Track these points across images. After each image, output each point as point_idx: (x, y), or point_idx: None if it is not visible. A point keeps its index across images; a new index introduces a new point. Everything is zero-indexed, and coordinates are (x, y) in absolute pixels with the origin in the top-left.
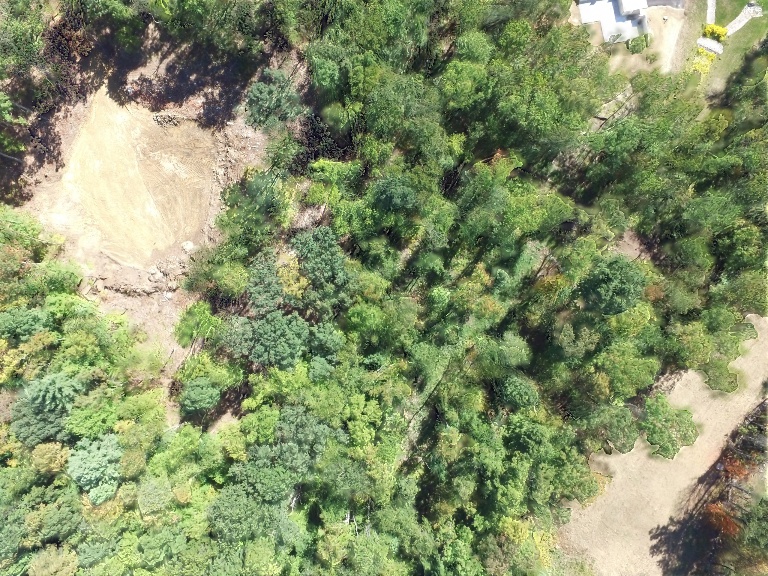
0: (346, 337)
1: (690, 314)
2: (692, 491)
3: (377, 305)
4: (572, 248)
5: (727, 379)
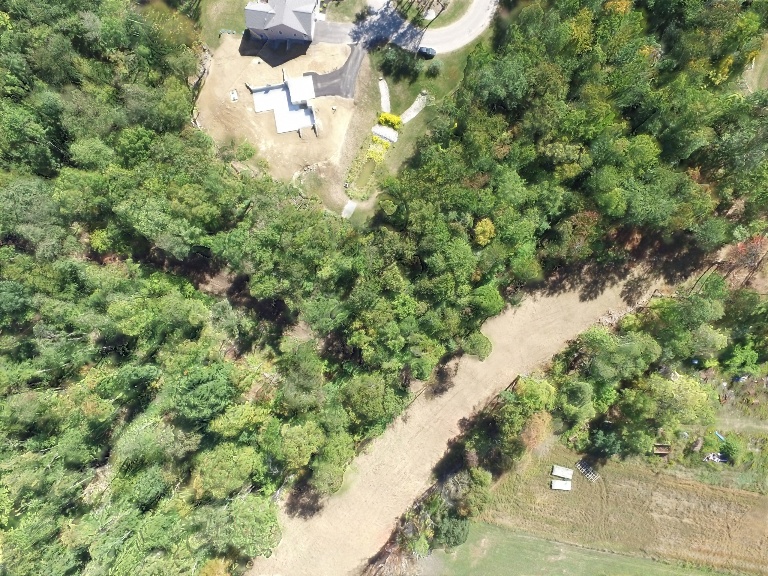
0: None
1: (309, 412)
2: (363, 571)
3: (2, 399)
4: (171, 353)
5: (326, 481)
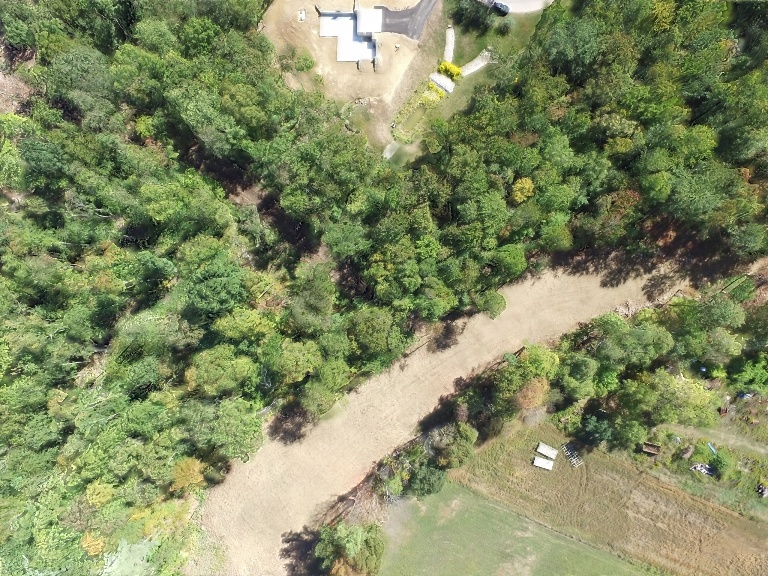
0: (5, 283)
1: (313, 333)
2: (331, 507)
3: (21, 258)
4: (192, 243)
5: (317, 401)
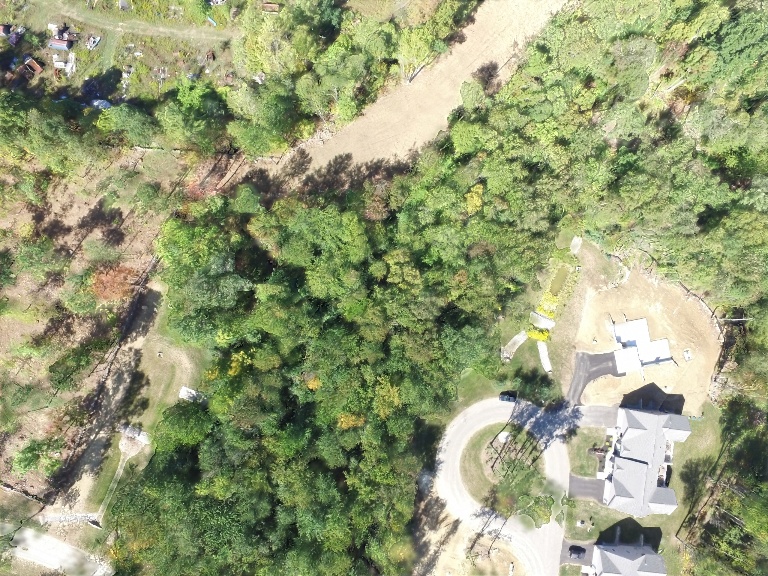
0: None
1: (629, 34)
2: None
3: None
4: None
5: None
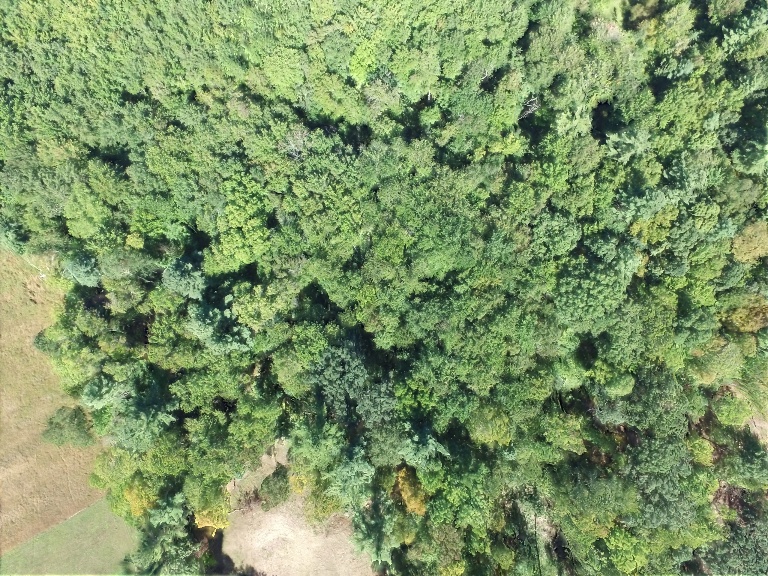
0: None
1: None
2: None
3: None
4: None
5: None
